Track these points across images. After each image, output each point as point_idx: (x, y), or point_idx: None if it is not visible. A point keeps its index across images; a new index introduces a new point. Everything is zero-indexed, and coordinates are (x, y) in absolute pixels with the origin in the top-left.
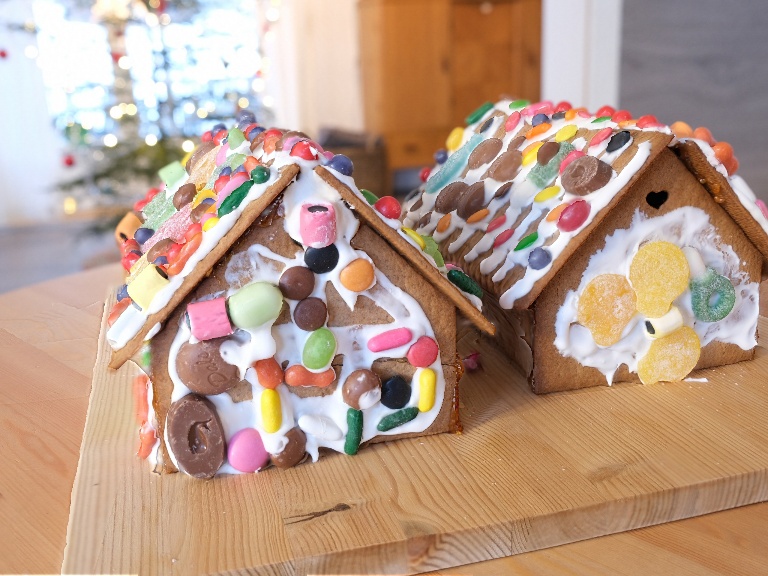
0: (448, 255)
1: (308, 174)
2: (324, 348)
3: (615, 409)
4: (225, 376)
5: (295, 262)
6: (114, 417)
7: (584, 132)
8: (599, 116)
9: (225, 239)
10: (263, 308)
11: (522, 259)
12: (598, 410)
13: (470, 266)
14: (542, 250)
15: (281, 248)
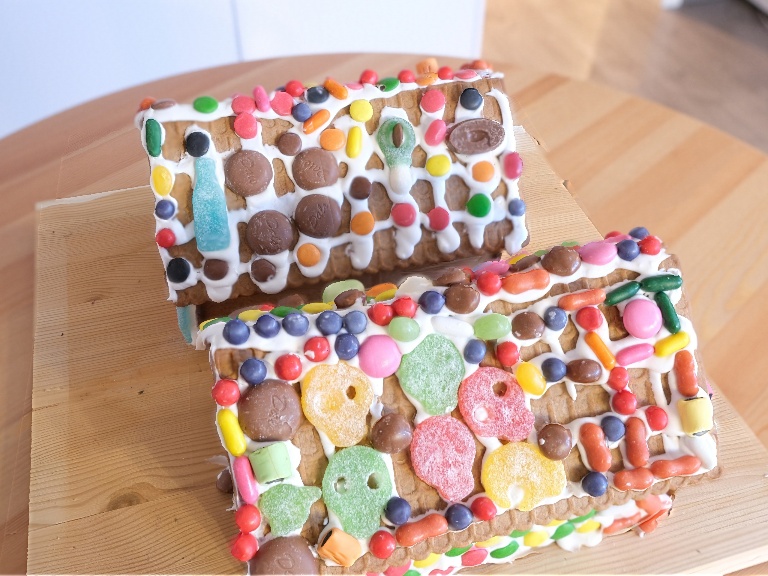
0: (355, 272)
1: None
2: None
3: None
4: None
5: None
6: None
7: (379, 102)
8: (374, 82)
9: None
10: None
11: (496, 217)
12: None
13: (413, 259)
14: (522, 200)
15: None
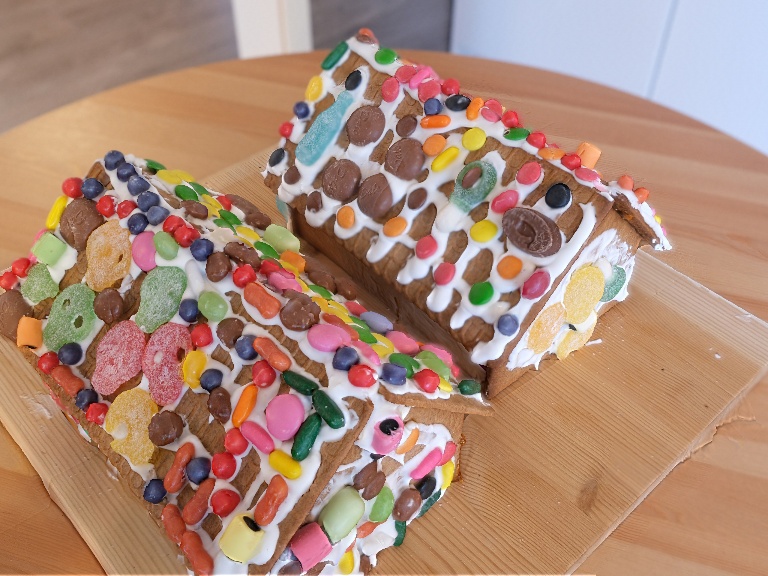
0: (365, 260)
1: (376, 400)
2: (391, 508)
3: (555, 403)
4: (320, 570)
5: (363, 462)
6: (148, 570)
7: (495, 143)
8: (507, 124)
9: (316, 487)
10: (356, 522)
11: (484, 315)
12: (544, 409)
13: (406, 289)
14: (512, 320)
15: (351, 457)
